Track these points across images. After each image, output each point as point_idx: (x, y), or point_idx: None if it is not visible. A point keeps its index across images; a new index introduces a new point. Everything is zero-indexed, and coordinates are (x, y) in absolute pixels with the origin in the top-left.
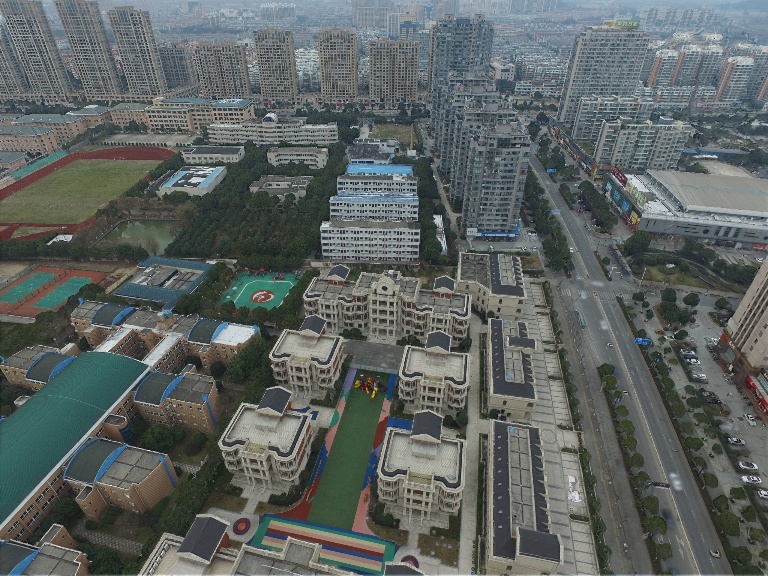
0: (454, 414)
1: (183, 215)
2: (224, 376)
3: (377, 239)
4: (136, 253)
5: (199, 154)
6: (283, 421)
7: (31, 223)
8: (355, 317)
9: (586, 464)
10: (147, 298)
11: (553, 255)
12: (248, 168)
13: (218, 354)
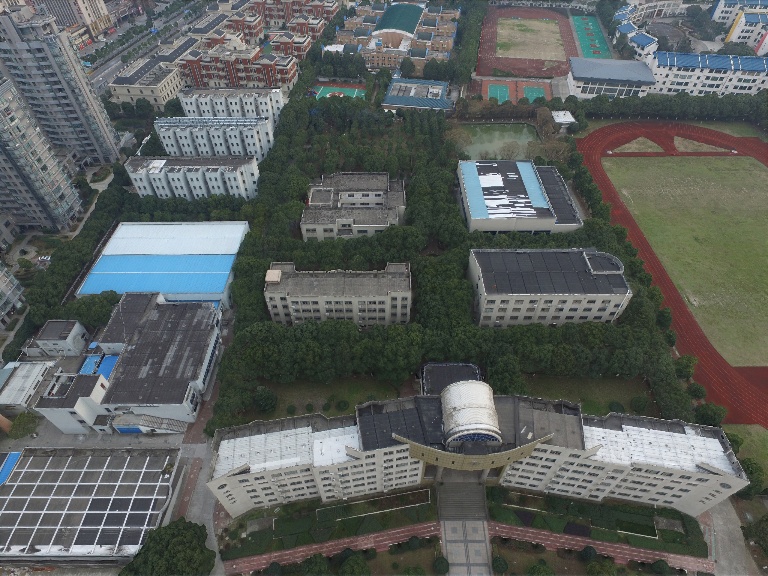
0: None
1: None
2: None
3: None
4: None
5: (561, 249)
6: None
7: (662, 156)
8: None
9: None
10: None
11: None
12: None
13: None
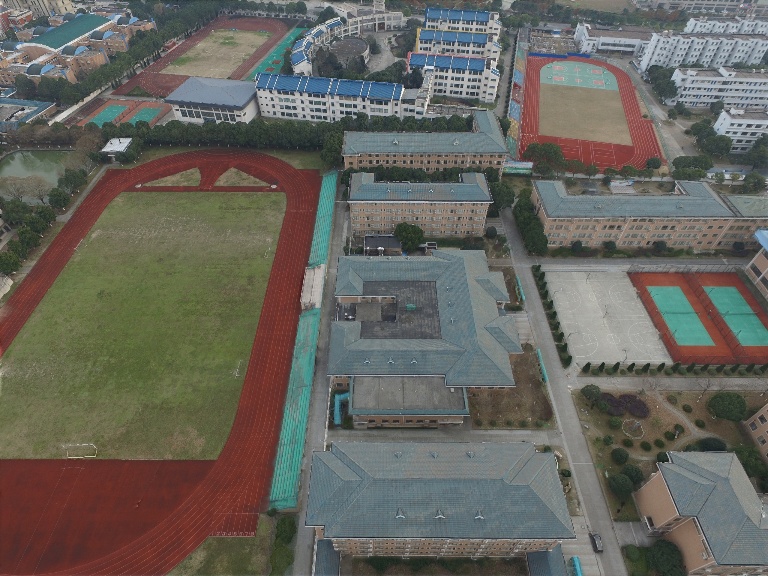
0: None
1: None
2: None
3: None
4: None
5: None
6: None
7: (188, 191)
8: None
9: None
10: None
11: None
12: None
13: None
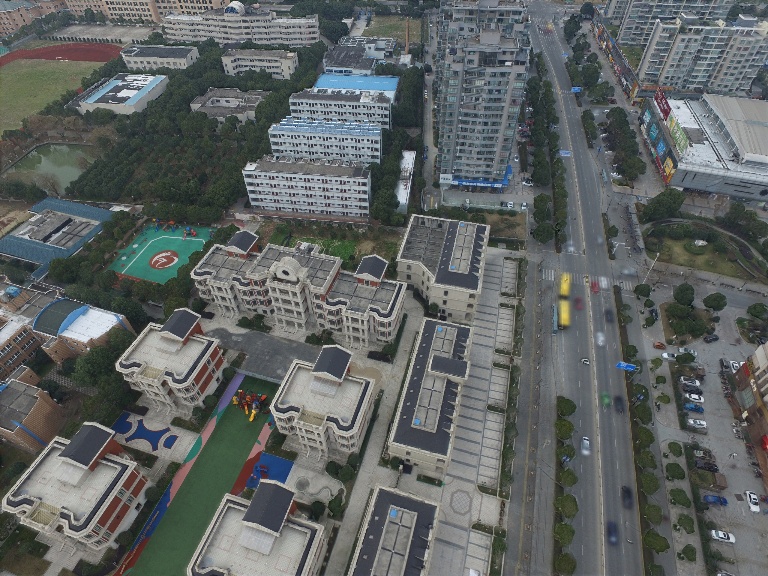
0: (346, 456)
1: (97, 142)
2: (71, 380)
3: (316, 188)
4: (28, 194)
5: (140, 57)
6: (95, 471)
7: None
8: (257, 302)
9: (498, 555)
10: (23, 257)
11: (543, 219)
12: (198, 77)
13: (73, 347)
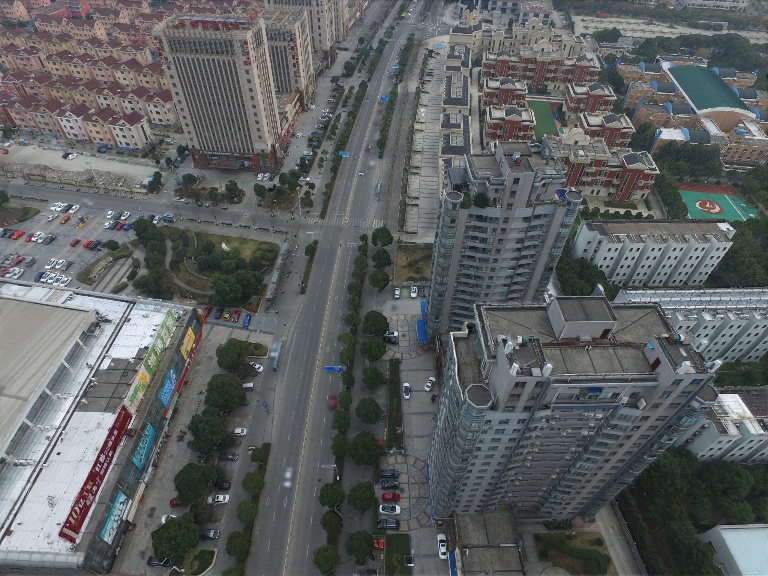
0: None
1: None
2: None
3: None
4: None
5: None
6: None
7: None
8: None
9: None
10: None
11: None
12: None
13: None
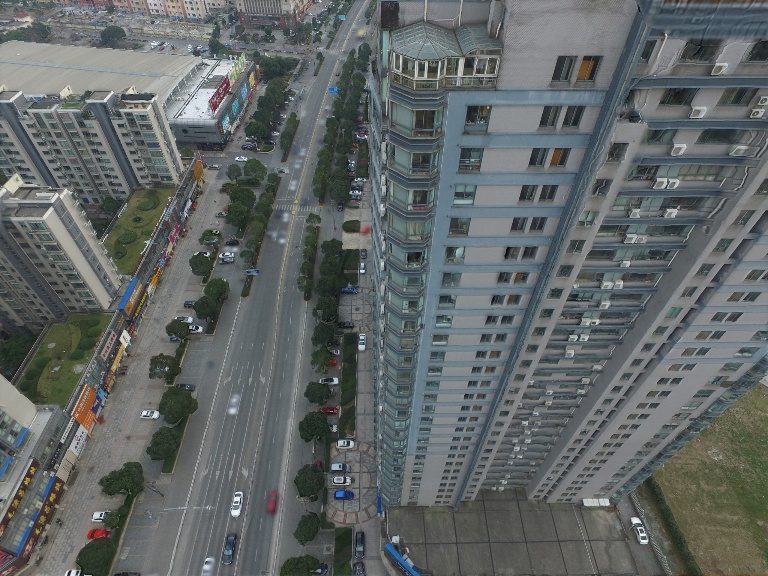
0: None
1: None
2: None
3: None
4: None
5: None
6: None
7: None
8: None
9: None
10: None
11: None
12: None
13: None
